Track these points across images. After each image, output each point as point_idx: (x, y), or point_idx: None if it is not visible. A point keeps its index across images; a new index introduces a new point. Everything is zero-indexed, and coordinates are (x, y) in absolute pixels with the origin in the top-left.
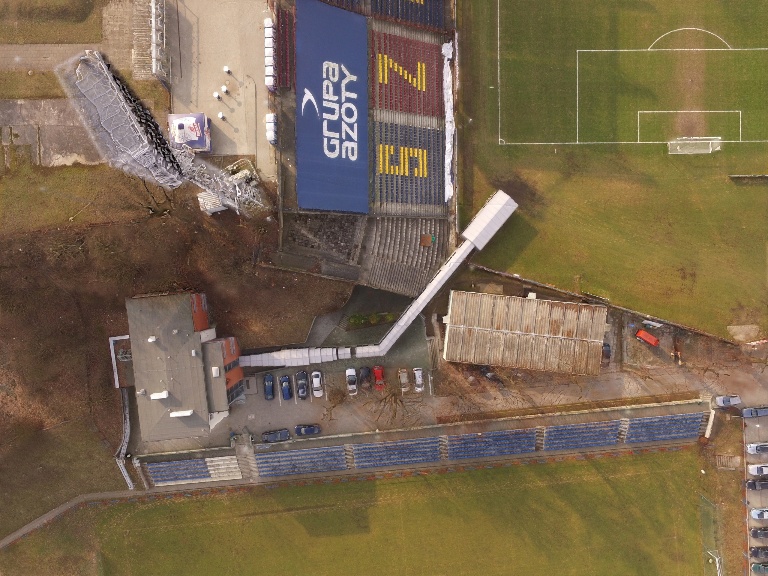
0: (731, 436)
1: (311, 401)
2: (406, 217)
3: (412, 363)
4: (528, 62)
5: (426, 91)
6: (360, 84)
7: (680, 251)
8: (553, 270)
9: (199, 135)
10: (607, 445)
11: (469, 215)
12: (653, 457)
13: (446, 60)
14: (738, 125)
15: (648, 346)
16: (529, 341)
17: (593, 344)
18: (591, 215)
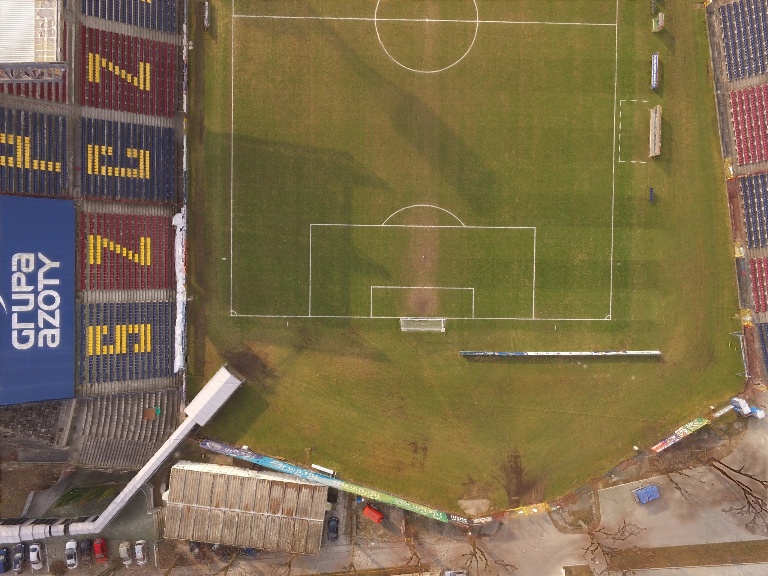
0: None
1: (32, 572)
2: (125, 393)
3: (137, 535)
4: (261, 235)
5: (151, 265)
6: (64, 269)
7: (412, 425)
8: (284, 442)
9: None
10: None
11: (200, 386)
12: None
13: (179, 230)
14: (471, 302)
15: None
16: (249, 519)
17: (313, 523)
18: (323, 388)
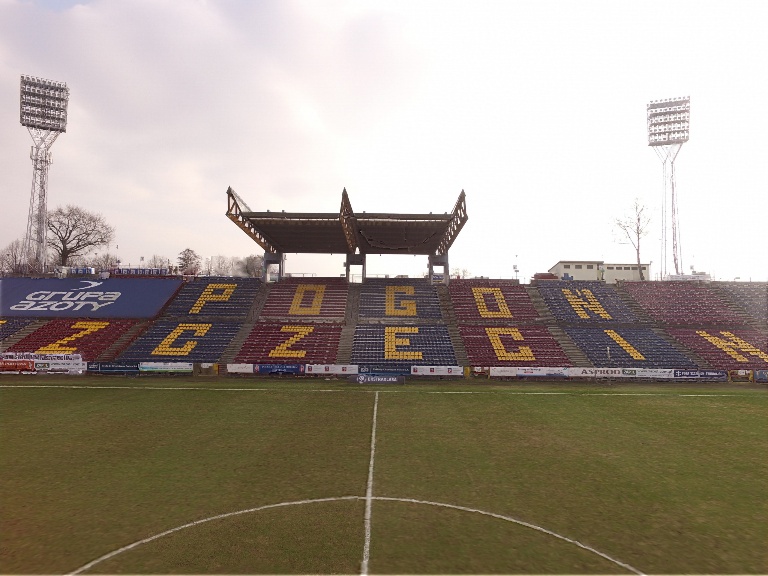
0: None
1: None
2: None
3: None
4: None
5: None
6: (86, 313)
7: None
8: None
9: (109, 269)
10: None
11: None
12: None
13: None
14: None
15: None
16: None
17: None
18: None
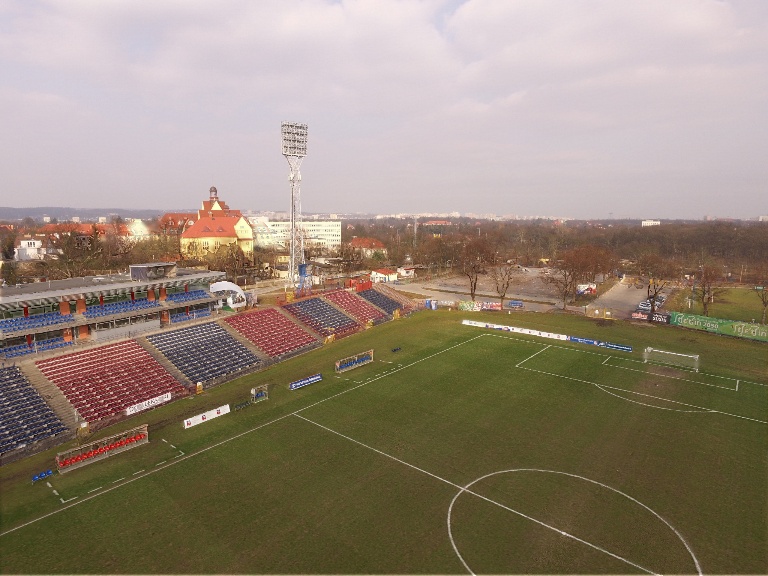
0: None
1: None
2: None
3: None
4: None
5: None
6: None
7: None
8: None
9: None
10: None
11: None
12: None
13: None
14: None
15: None
16: None
17: None
18: None
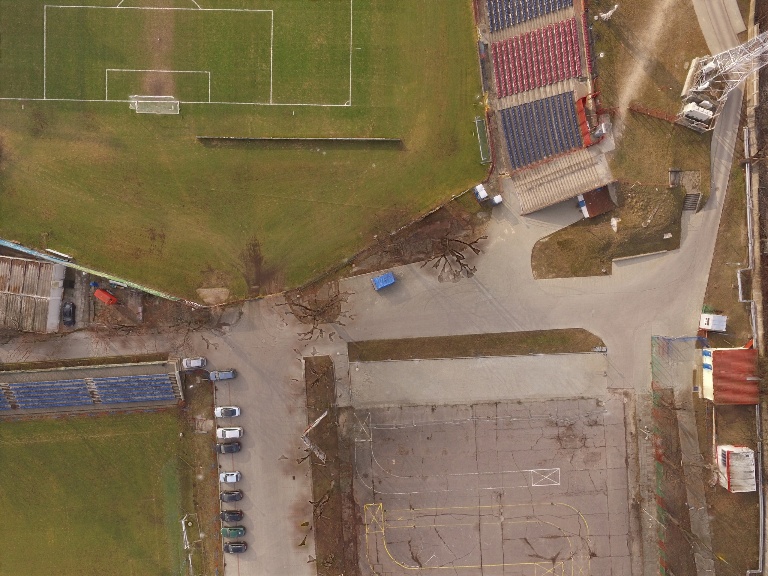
0: (204, 399)
1: None
2: None
3: None
4: None
5: None
6: None
7: (149, 212)
8: (21, 227)
9: None
10: (85, 405)
11: None
12: (133, 419)
13: None
14: (207, 86)
15: (116, 306)
16: None
17: (40, 301)
18: (59, 173)
